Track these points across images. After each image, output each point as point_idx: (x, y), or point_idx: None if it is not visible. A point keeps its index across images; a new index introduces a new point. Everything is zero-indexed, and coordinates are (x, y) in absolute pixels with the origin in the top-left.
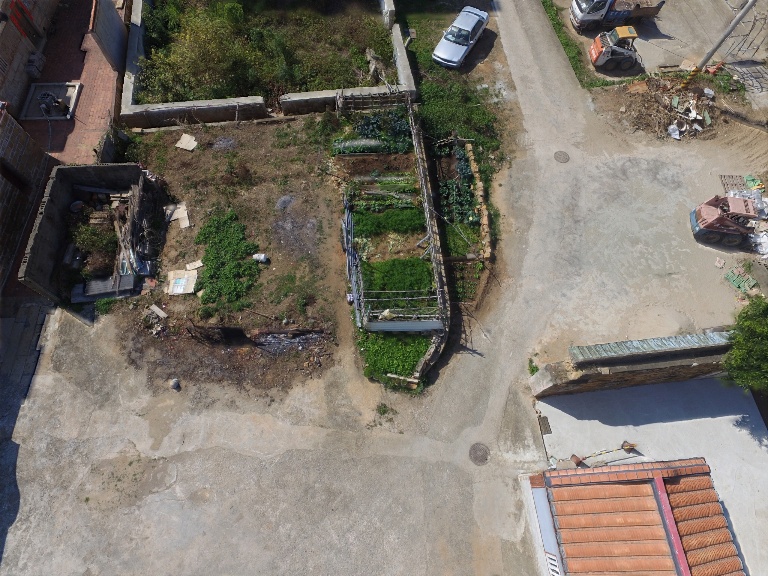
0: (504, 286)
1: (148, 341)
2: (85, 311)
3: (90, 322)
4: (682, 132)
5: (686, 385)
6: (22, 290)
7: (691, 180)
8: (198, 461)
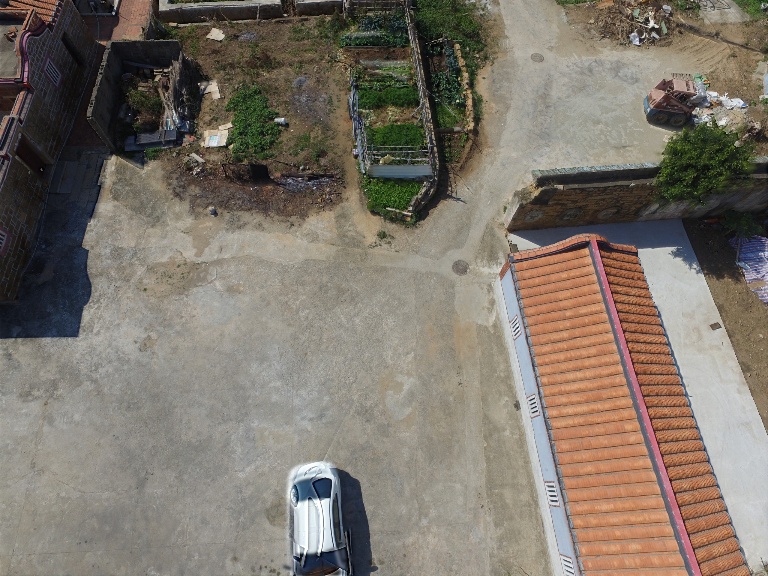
0: (485, 153)
1: (189, 180)
2: (136, 158)
3: (141, 166)
4: (642, 40)
5: (632, 225)
6: (83, 142)
7: (647, 77)
8: (233, 265)
